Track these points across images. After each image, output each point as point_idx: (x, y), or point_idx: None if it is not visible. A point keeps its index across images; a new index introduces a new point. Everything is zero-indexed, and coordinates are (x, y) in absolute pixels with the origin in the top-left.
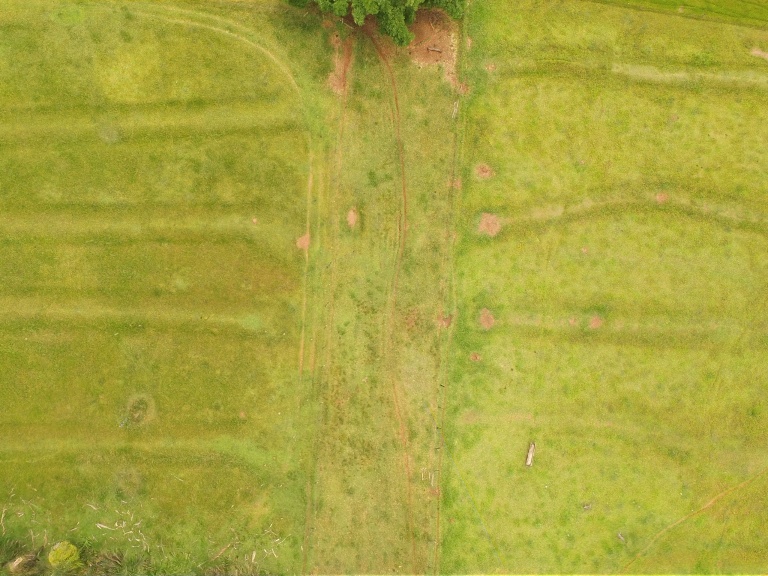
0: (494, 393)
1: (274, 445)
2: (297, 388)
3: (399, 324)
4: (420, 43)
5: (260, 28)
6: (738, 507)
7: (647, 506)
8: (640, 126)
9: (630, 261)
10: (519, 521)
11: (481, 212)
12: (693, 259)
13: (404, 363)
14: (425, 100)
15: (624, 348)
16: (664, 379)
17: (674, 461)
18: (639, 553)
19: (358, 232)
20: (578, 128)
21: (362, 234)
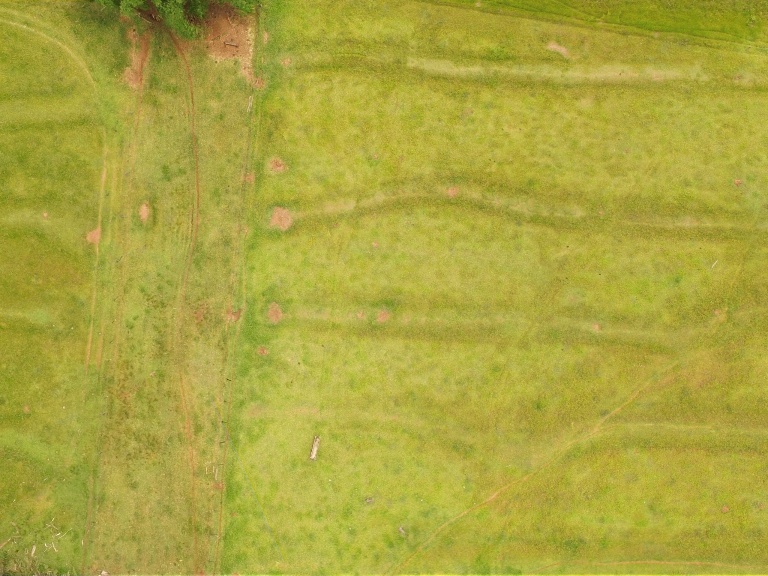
0: (280, 387)
1: (57, 439)
2: (83, 382)
3: (188, 318)
4: (218, 37)
5: (57, 23)
6: (521, 500)
7: (429, 499)
8: (434, 120)
9: (420, 255)
10: (302, 515)
11: (273, 206)
12: (483, 253)
13: (192, 357)
14: (221, 94)
15: (412, 342)
16: (451, 373)
17: (458, 454)
18: (420, 546)
19: (150, 226)
20: (373, 122)
21: (154, 228)
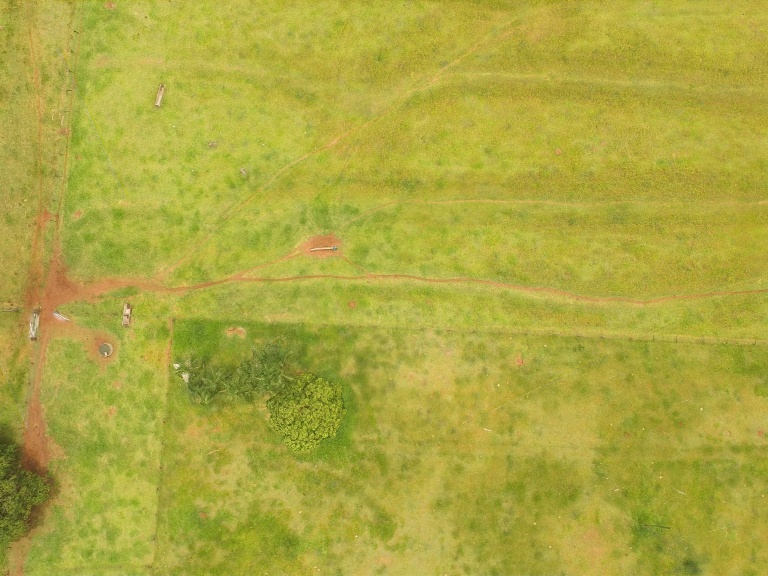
0: (127, 39)
1: None
2: None
3: None
4: None
5: None
6: (360, 145)
7: (271, 143)
8: None
9: None
10: (145, 158)
11: None
12: None
13: (41, 12)
14: None
15: None
16: (295, 27)
17: (300, 103)
18: (261, 187)
19: None
20: None
21: None
